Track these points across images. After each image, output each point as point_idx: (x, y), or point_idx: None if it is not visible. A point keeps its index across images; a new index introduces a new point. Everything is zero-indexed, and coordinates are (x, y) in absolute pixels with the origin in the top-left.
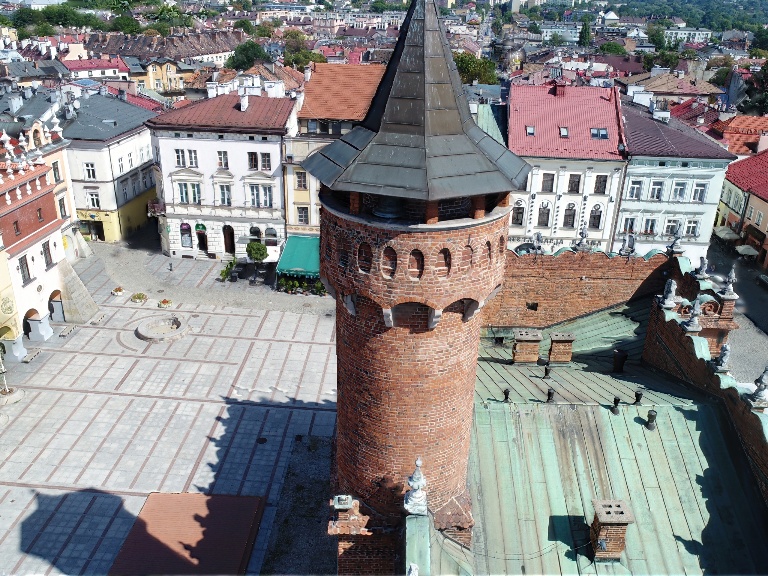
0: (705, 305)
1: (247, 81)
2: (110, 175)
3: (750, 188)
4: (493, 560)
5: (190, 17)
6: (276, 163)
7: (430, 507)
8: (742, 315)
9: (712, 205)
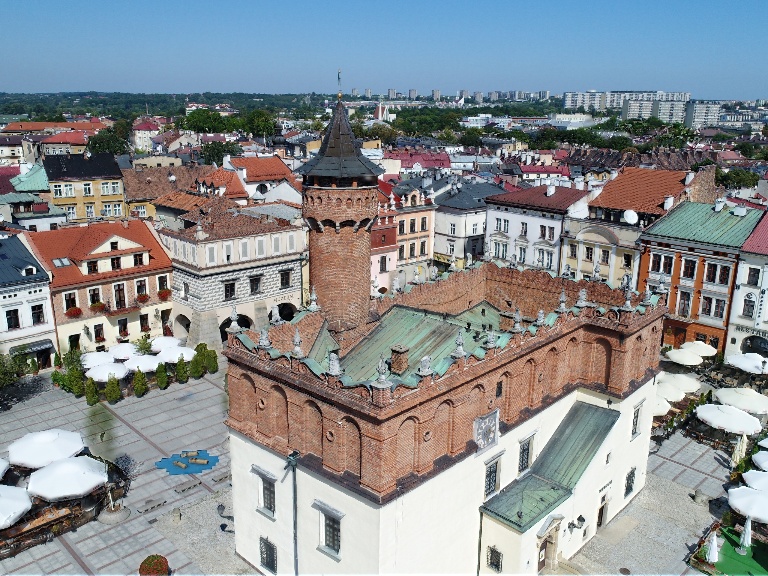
0: (610, 313)
1: (577, 178)
2: (463, 233)
3: None
4: (356, 361)
5: (677, 138)
6: (558, 235)
7: (328, 319)
8: None
9: None
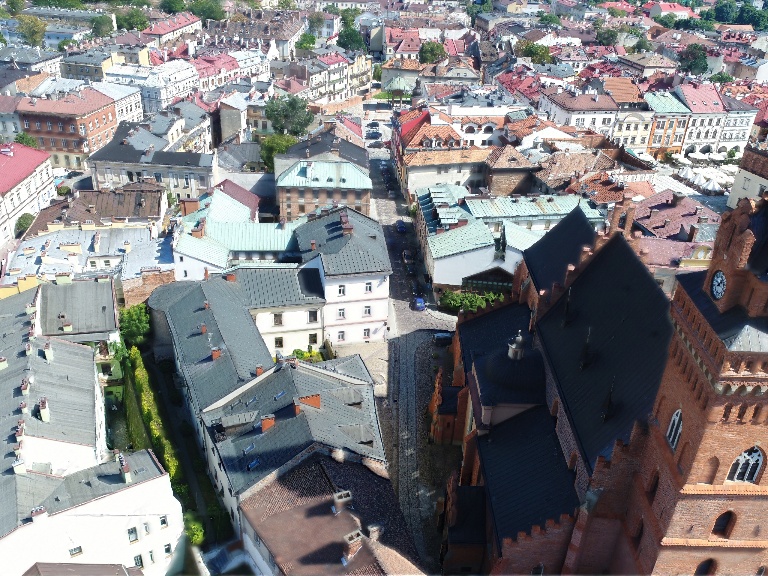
0: None
1: None
2: None
3: None
4: None
5: None
6: (613, 121)
7: None
8: None
9: (751, 126)
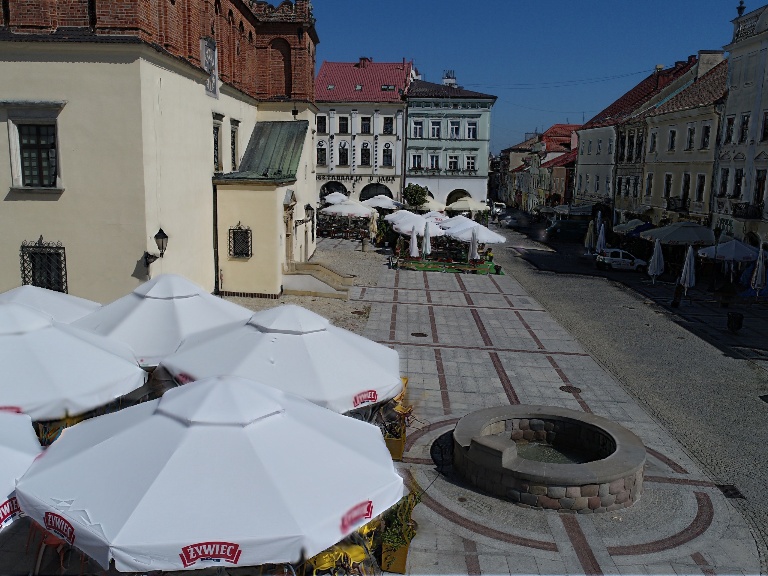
0: (284, 6)
1: None
2: None
3: None
4: None
5: None
6: None
7: None
8: (516, 232)
9: (484, 141)
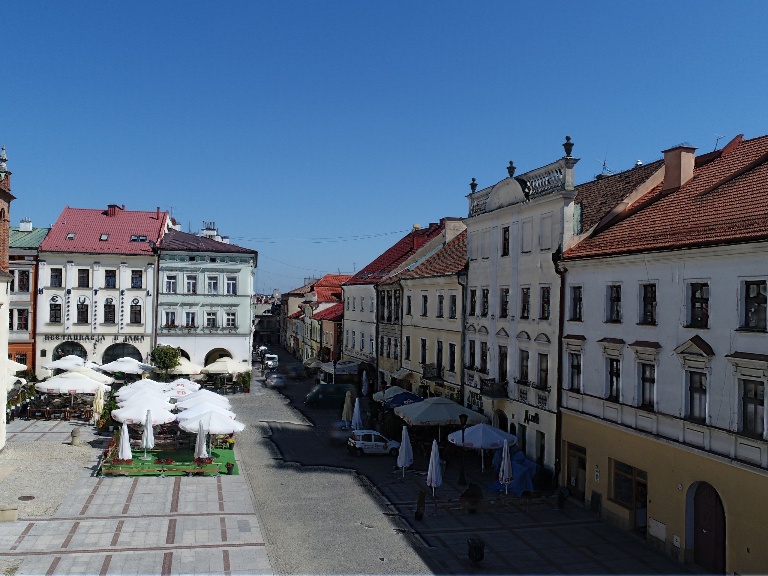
0: None
1: None
2: None
3: (322, 317)
4: None
5: None
6: None
7: None
8: (280, 394)
9: (245, 297)
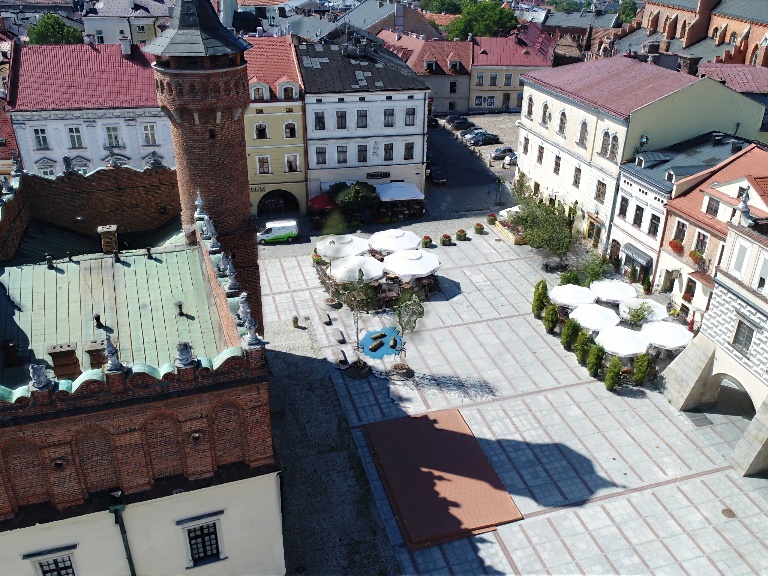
0: None
1: None
2: None
3: None
4: None
5: None
6: None
7: None
8: None
9: None
